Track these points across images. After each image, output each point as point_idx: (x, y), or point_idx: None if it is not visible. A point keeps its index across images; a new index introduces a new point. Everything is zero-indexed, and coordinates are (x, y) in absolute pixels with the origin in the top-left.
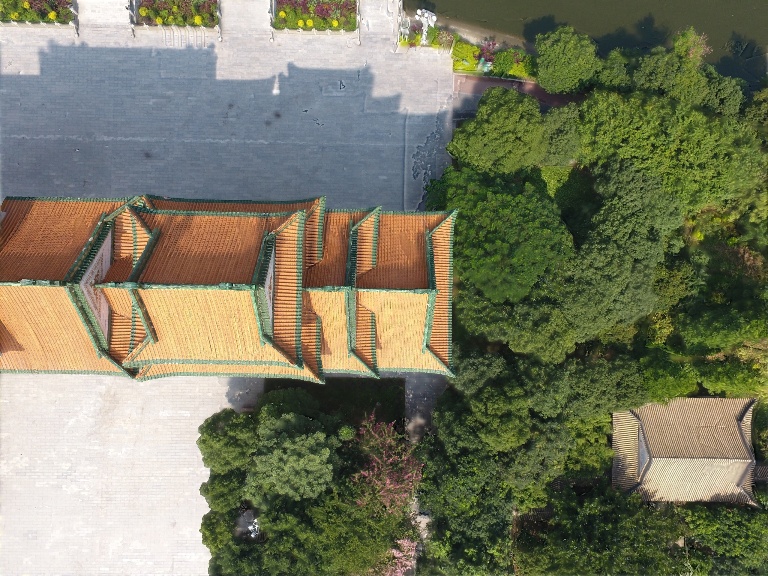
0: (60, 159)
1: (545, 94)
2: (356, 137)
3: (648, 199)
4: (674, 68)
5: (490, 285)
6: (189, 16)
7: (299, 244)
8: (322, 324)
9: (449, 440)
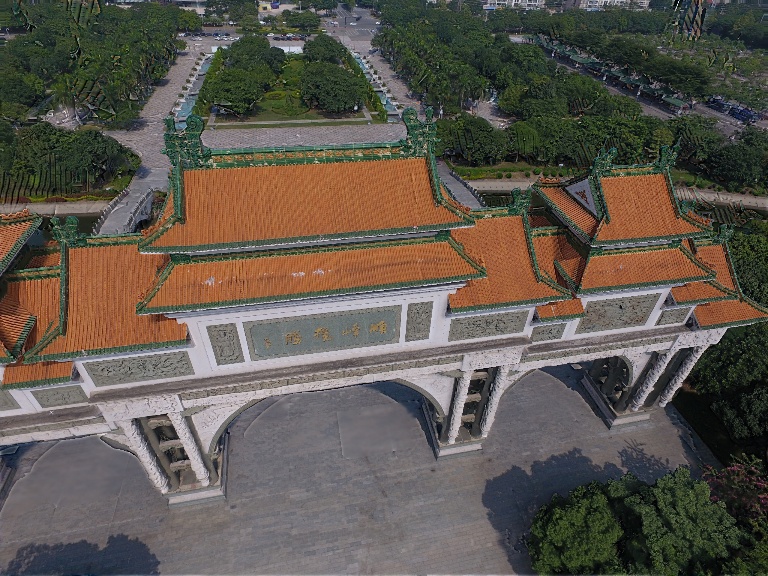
0: None
1: None
2: None
3: (760, 274)
4: None
5: None
6: None
7: None
8: None
9: None
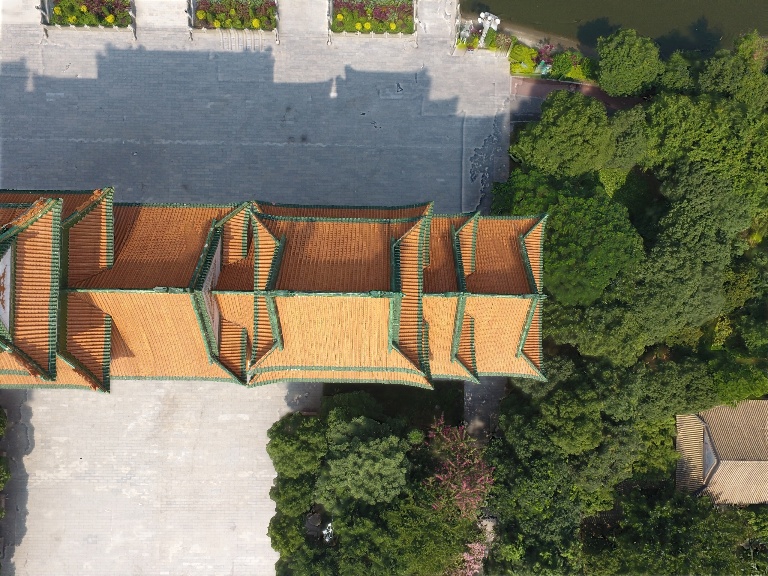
0: (118, 163)
1: (602, 96)
2: (414, 140)
3: (718, 202)
4: (740, 71)
5: (562, 288)
6: (246, 19)
7: (420, 250)
8: (429, 329)
9: (521, 443)
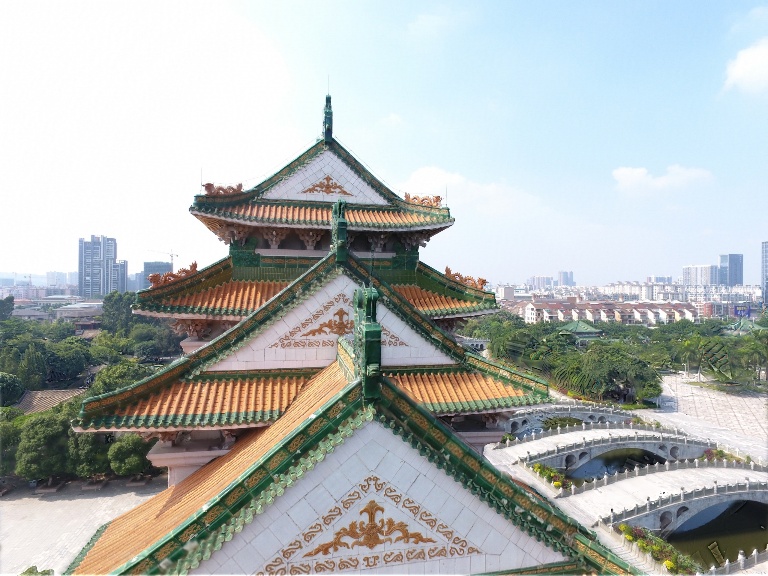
0: None
1: None
2: None
3: None
4: None
5: None
6: None
7: None
8: None
9: None
